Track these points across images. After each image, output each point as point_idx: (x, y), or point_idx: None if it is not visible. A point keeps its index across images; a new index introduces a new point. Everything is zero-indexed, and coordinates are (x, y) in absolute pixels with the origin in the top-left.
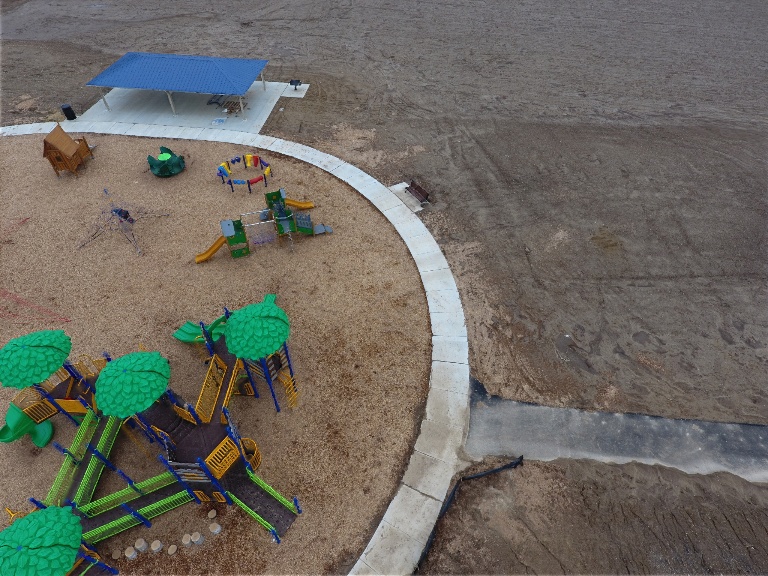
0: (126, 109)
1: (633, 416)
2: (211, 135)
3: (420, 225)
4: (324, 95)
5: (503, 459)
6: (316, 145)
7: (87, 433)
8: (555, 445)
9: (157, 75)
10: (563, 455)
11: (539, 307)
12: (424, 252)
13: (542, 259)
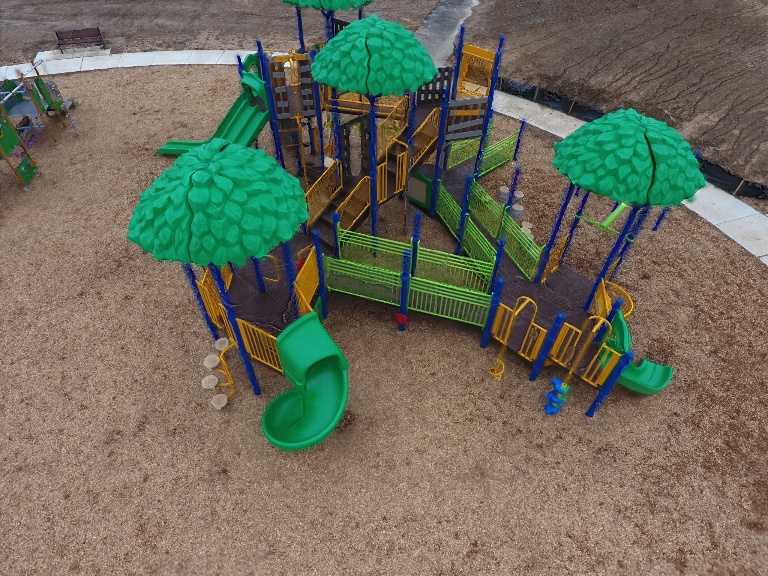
0: None
1: (427, 18)
2: None
3: (138, 54)
4: None
5: (450, 60)
6: None
7: None
8: (443, 42)
9: None
10: (451, 42)
11: (311, 23)
12: (187, 57)
13: (258, 9)
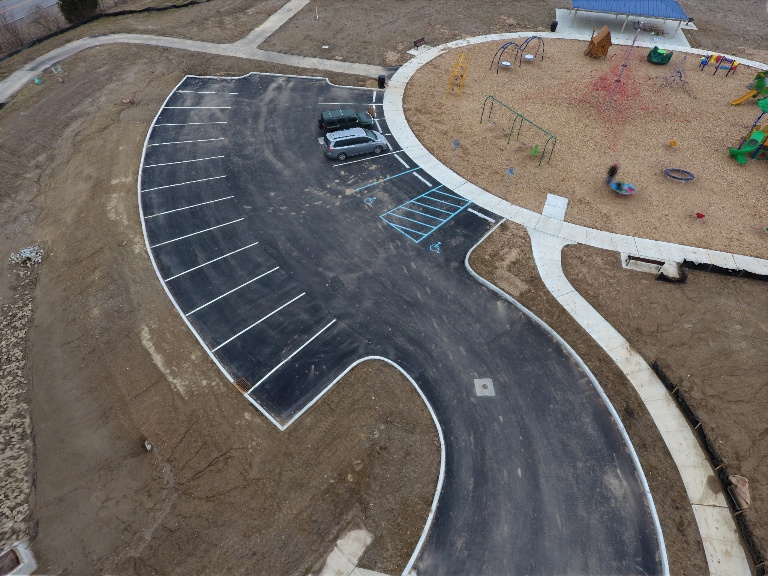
0: (582, 28)
1: None
2: (660, 46)
3: None
4: (710, 30)
5: None
6: (740, 56)
7: (760, 162)
8: None
9: (621, 4)
10: None
11: None
12: None
13: None
